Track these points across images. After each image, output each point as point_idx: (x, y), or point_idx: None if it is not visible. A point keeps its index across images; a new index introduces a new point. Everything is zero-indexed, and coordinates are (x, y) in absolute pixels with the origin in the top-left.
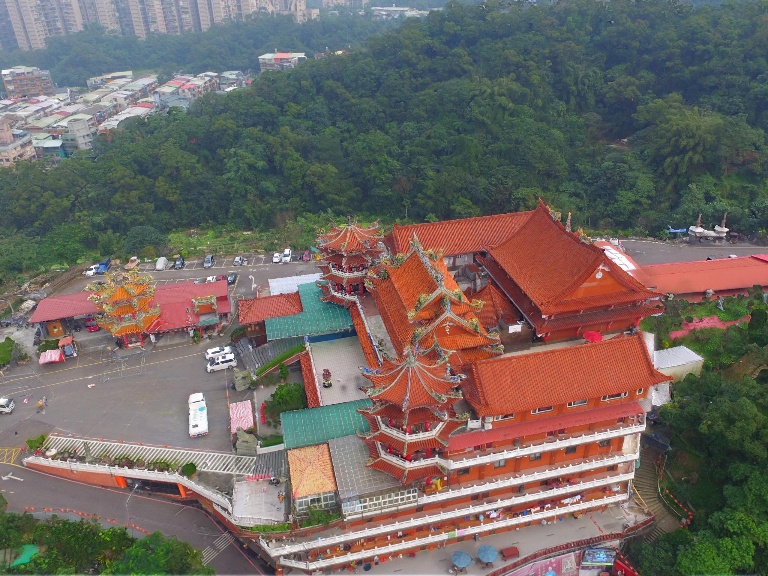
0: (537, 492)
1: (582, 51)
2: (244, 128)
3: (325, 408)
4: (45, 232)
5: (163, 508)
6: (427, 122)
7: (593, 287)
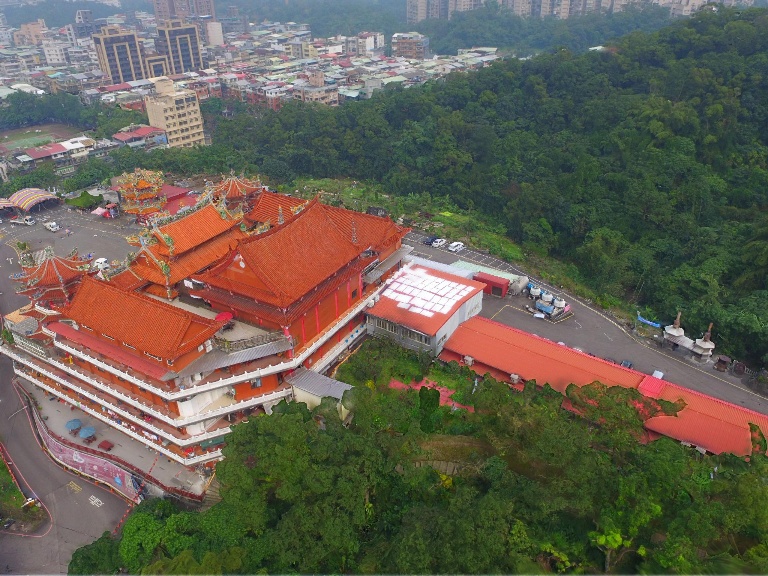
0: None
1: None
2: None
3: None
4: None
5: None
6: (580, 134)
7: (241, 274)
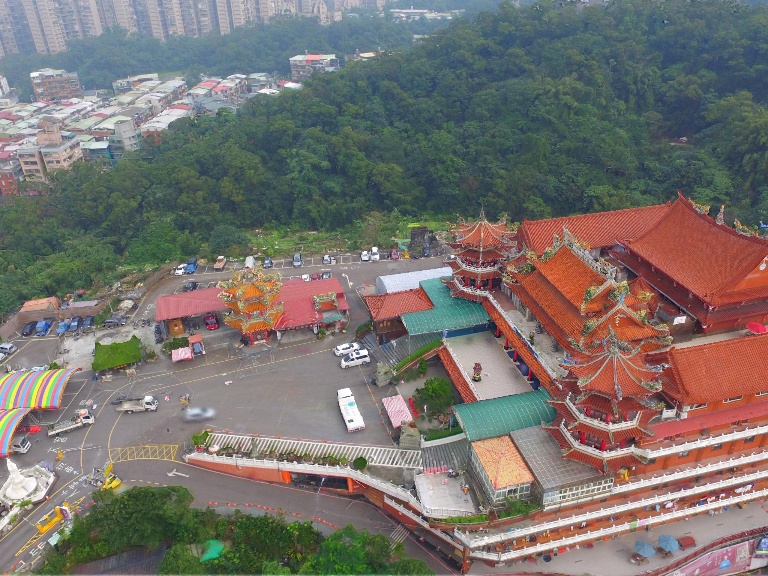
0: (717, 481)
1: (642, 50)
2: (302, 128)
3: (497, 401)
4: (136, 232)
5: (332, 502)
6: (490, 121)
7: (755, 279)
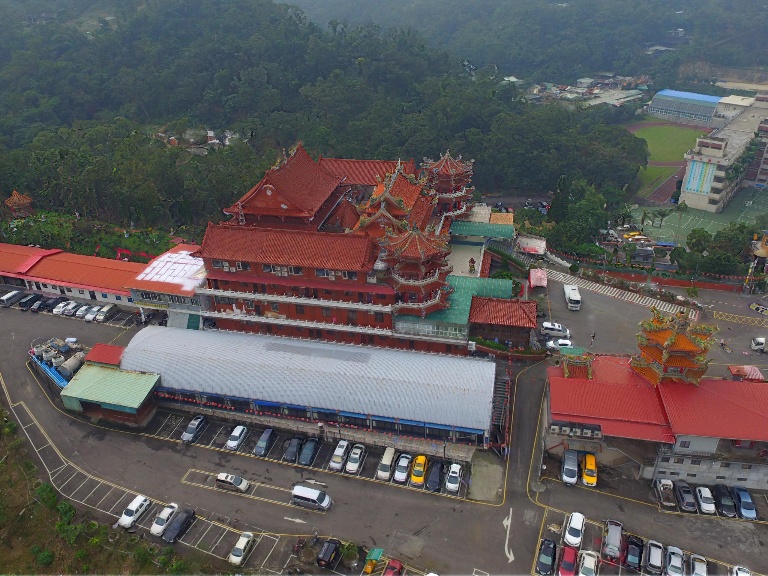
0: None
1: None
2: None
3: (485, 230)
4: None
5: None
6: None
7: None
